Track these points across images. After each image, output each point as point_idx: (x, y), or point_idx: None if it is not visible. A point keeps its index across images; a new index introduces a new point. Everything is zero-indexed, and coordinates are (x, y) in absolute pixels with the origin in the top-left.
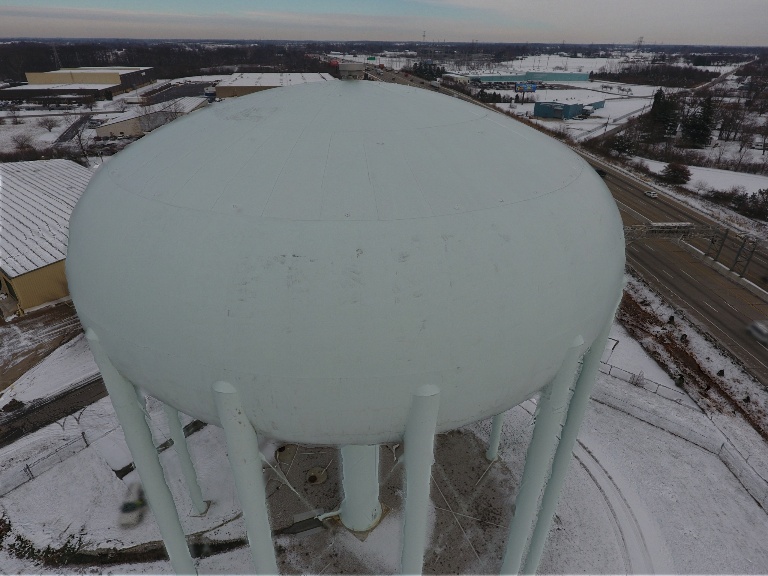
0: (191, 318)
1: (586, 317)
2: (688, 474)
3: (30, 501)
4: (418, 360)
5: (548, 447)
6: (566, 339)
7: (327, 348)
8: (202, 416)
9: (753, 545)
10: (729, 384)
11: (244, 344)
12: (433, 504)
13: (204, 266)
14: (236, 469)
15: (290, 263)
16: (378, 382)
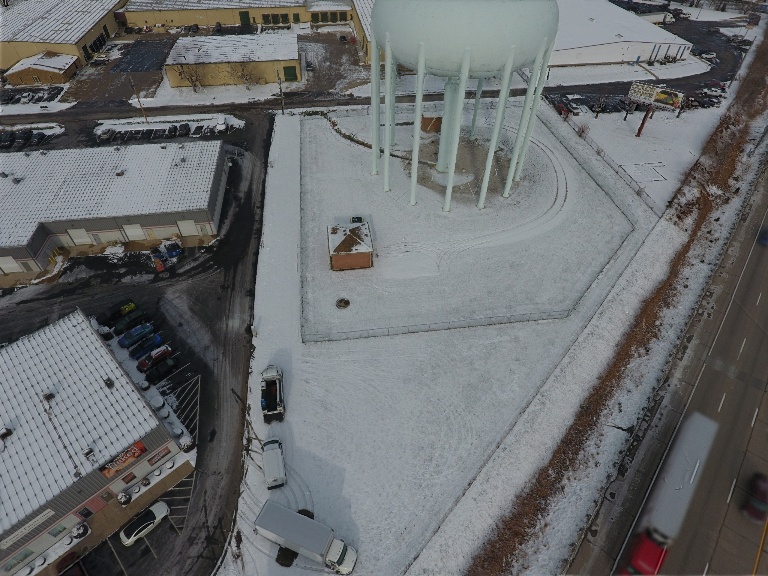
0: (386, 14)
1: (473, 42)
2: (604, 222)
3: (345, 122)
4: (421, 34)
5: (461, 89)
6: (463, 46)
7: (405, 26)
8: (384, 46)
9: (594, 244)
10: (713, 225)
11: (392, 22)
12: (474, 178)
13: (392, 3)
14: (386, 60)
15: (405, 4)
16: (412, 37)
